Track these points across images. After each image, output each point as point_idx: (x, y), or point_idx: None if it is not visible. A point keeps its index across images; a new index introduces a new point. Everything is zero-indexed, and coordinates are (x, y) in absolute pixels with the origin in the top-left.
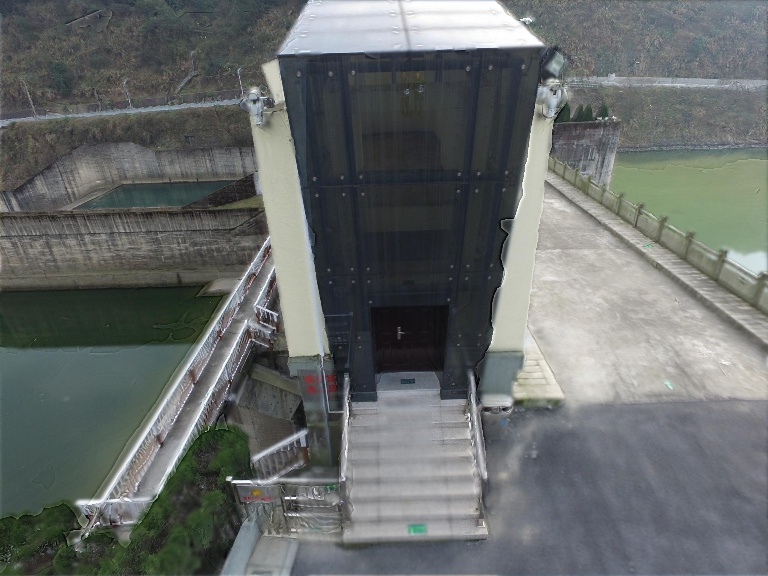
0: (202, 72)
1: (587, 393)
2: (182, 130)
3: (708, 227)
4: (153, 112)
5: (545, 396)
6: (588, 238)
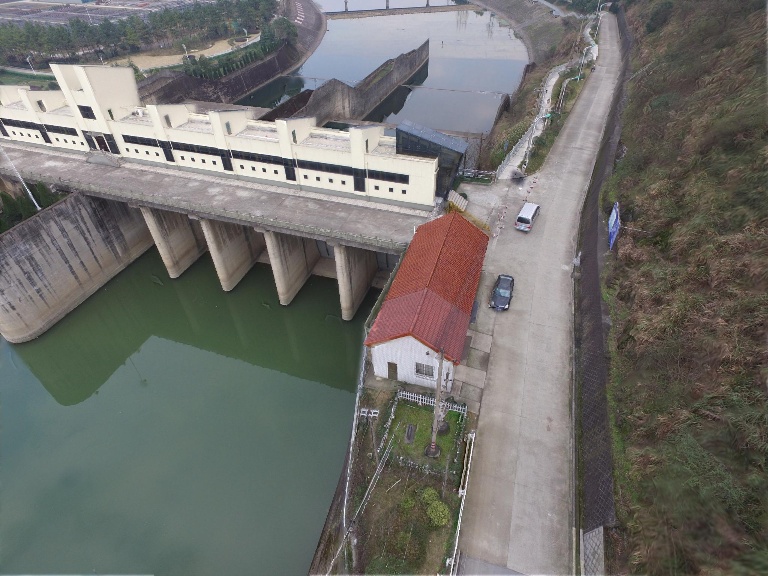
0: None
1: None
2: None
3: None
4: None
5: None
6: None
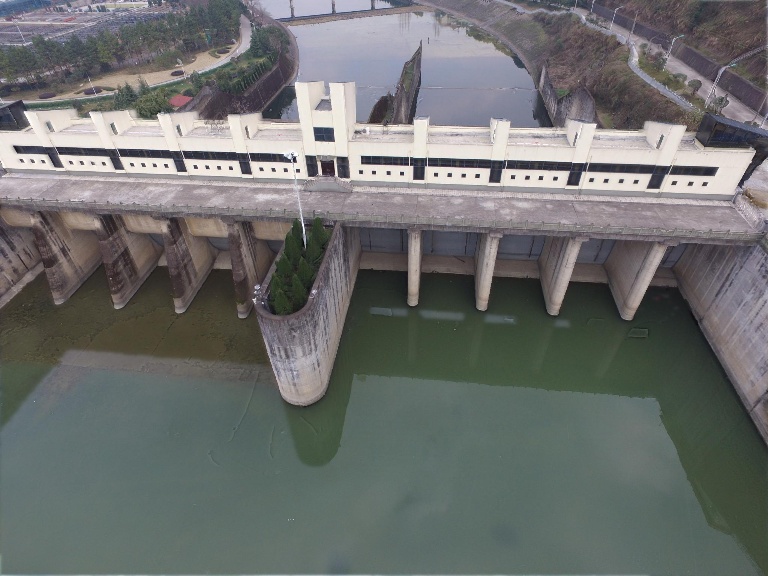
0: (767, 49)
1: (1, 180)
2: (631, 109)
3: (269, 567)
4: (641, 80)
5: (4, 175)
6: (44, 197)
